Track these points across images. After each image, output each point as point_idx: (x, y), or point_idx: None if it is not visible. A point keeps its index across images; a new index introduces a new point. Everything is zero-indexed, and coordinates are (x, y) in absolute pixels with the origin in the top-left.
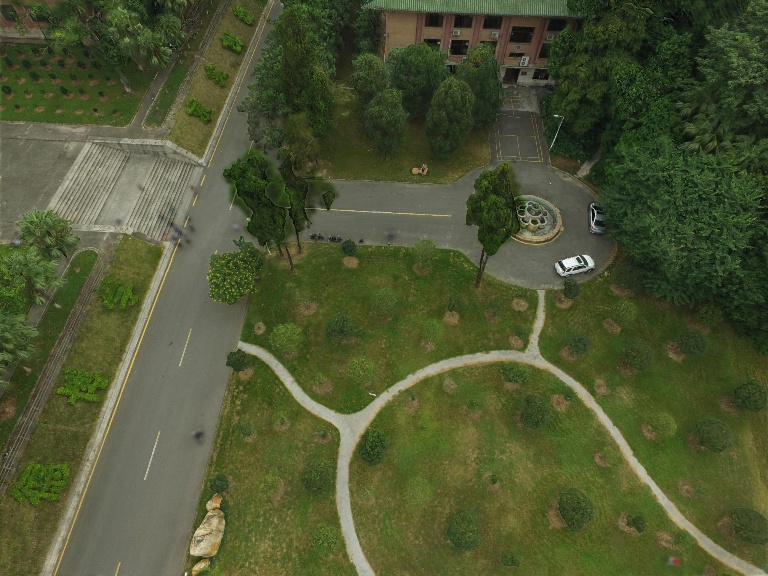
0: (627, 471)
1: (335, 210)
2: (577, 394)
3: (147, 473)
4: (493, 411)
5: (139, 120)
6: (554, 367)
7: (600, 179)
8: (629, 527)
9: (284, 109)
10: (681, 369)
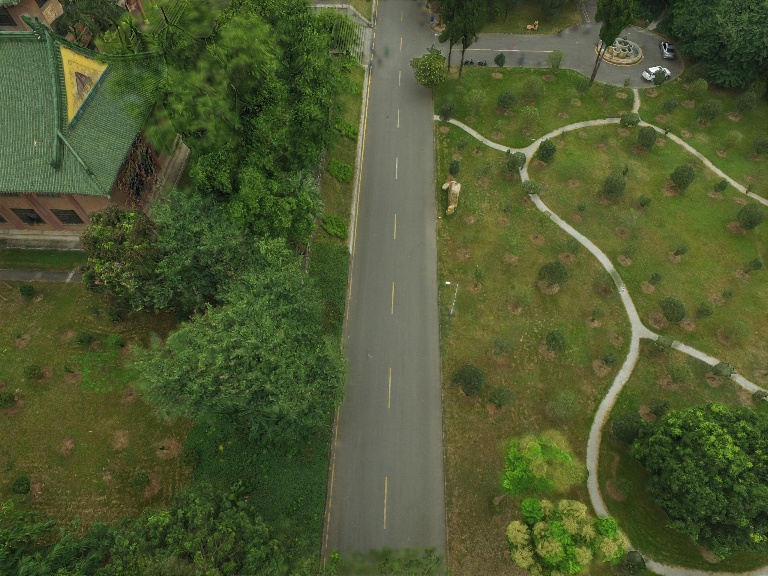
0: (709, 171)
1: (476, 50)
2: (670, 138)
3: (397, 176)
4: (615, 146)
5: None
6: (652, 125)
7: (666, 27)
8: (715, 195)
9: None
10: (738, 124)
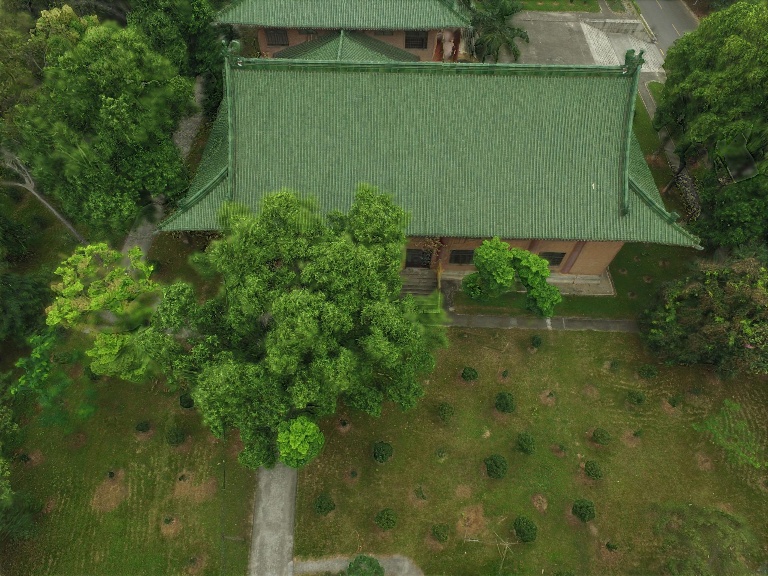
0: None
1: None
2: None
3: None
4: None
5: (606, 8)
6: None
7: None
8: None
9: None
10: None
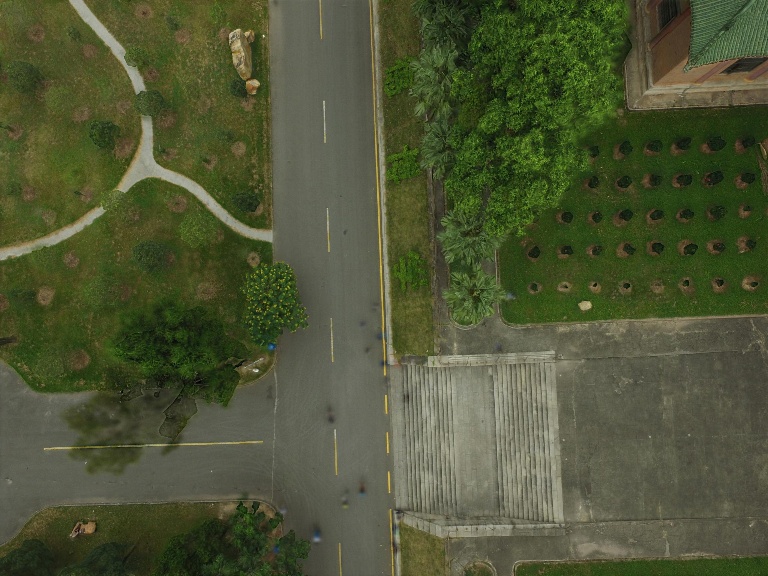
0: None
1: (197, 444)
2: None
3: (324, 106)
4: (8, 195)
5: None
6: None
7: None
8: None
9: (218, 571)
10: None
